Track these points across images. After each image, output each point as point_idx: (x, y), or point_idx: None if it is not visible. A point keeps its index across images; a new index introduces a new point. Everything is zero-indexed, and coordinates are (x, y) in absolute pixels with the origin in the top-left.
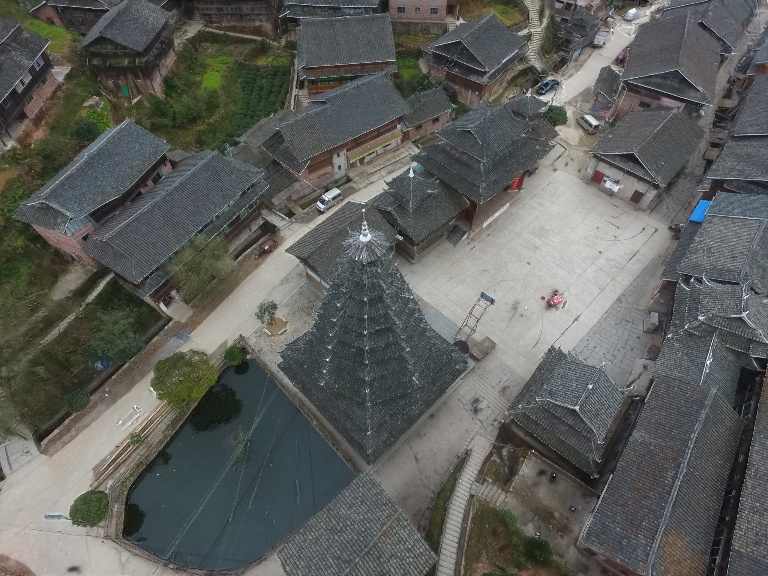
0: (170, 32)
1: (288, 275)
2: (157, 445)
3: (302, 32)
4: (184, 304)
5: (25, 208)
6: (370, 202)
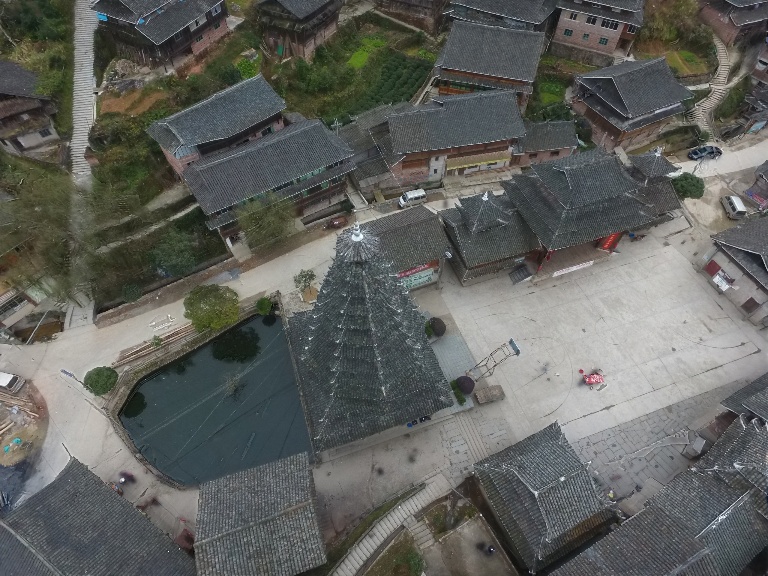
0: (336, 7)
1: None
2: (173, 354)
3: (451, 33)
4: (247, 247)
5: (156, 126)
6: (442, 212)
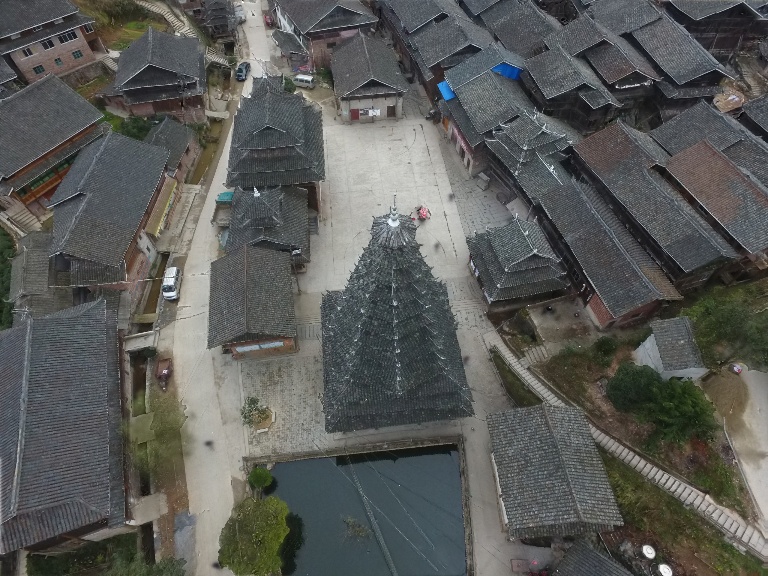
0: None
1: (216, 374)
2: None
3: None
4: (146, 498)
5: None
6: (229, 249)
